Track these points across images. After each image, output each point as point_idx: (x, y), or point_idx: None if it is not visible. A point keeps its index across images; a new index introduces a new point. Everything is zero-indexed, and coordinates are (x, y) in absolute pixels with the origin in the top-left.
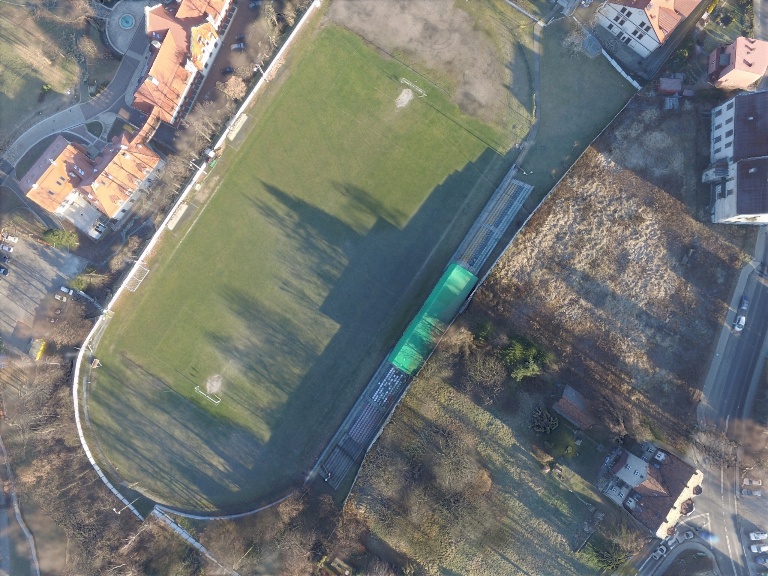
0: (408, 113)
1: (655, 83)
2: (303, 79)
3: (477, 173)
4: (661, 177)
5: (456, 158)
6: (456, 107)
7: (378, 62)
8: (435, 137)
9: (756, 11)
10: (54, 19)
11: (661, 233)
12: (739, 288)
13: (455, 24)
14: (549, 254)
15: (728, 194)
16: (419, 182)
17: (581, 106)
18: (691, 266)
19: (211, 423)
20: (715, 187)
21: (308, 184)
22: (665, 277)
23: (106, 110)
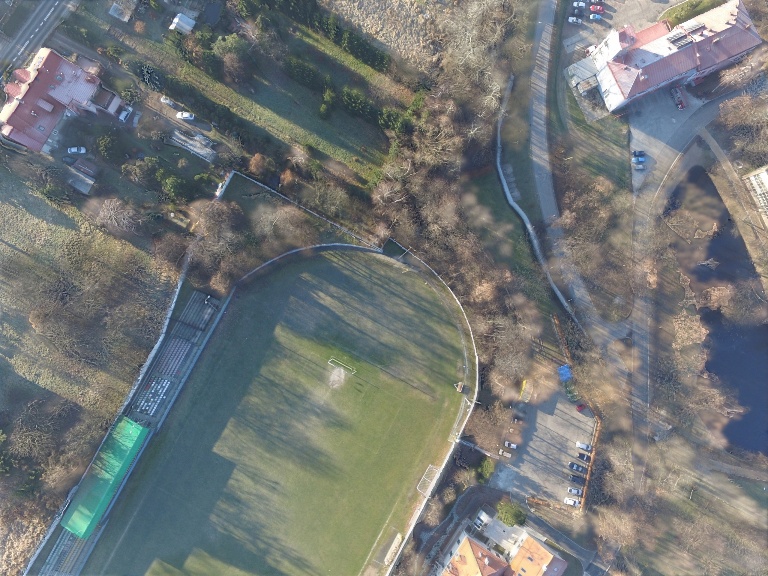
0: None
1: None
2: None
3: None
4: None
5: None
6: None
7: None
8: None
9: None
10: None
11: None
12: None
13: None
14: None
15: None
16: None
17: None
18: None
19: (336, 338)
20: None
21: None
22: None
23: None
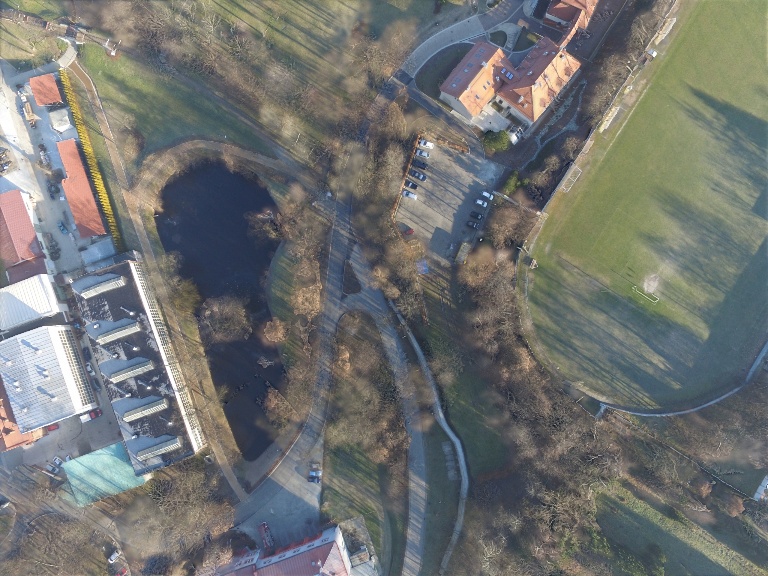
0: None
1: None
2: None
3: None
4: None
5: None
6: None
7: None
8: None
9: None
10: None
11: None
12: None
13: None
14: None
15: None
16: None
17: None
18: None
19: (650, 322)
20: None
21: (735, 87)
22: None
23: (505, 21)
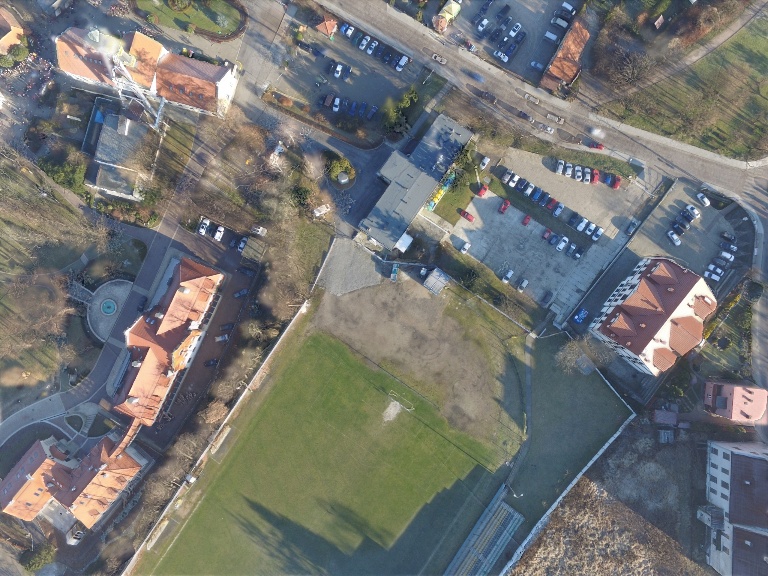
0: (396, 427)
1: (649, 414)
2: (288, 389)
3: (466, 491)
4: (655, 512)
5: (445, 475)
6: (445, 421)
7: (365, 373)
8: (423, 453)
9: (754, 329)
10: (32, 328)
11: (654, 572)
12: None
13: (445, 333)
14: None
15: (723, 549)
16: (406, 500)
17: (573, 424)
18: None
19: None
20: (710, 530)
21: (292, 501)
22: None
23: (87, 400)
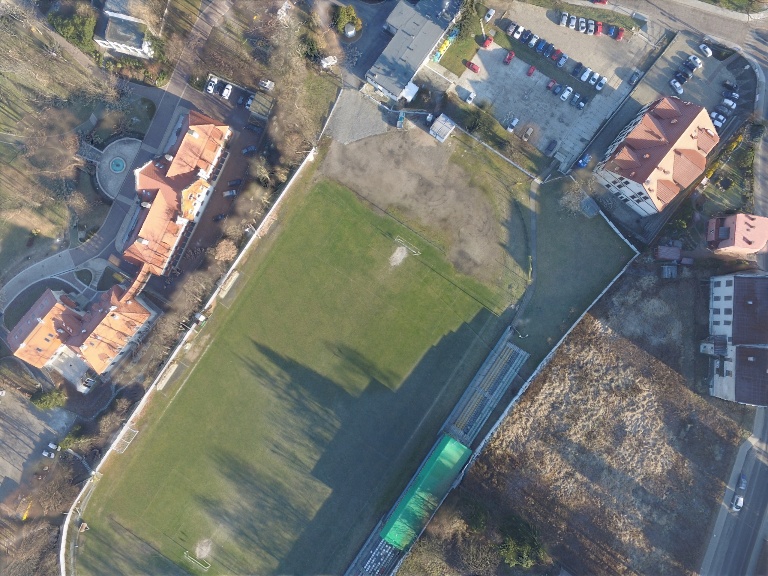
0: (402, 272)
1: (653, 250)
2: (296, 235)
3: (472, 334)
4: (659, 347)
5: (451, 318)
6: (451, 266)
7: (372, 219)
8: (429, 296)
9: (756, 172)
10: (43, 174)
11: (658, 405)
12: (737, 466)
13: (450, 180)
14: (544, 424)
15: (726, 374)
16: (413, 343)
17: (578, 267)
18: (689, 441)
19: None
20: (713, 361)
21: (300, 344)
22: (662, 452)
23: (96, 256)
